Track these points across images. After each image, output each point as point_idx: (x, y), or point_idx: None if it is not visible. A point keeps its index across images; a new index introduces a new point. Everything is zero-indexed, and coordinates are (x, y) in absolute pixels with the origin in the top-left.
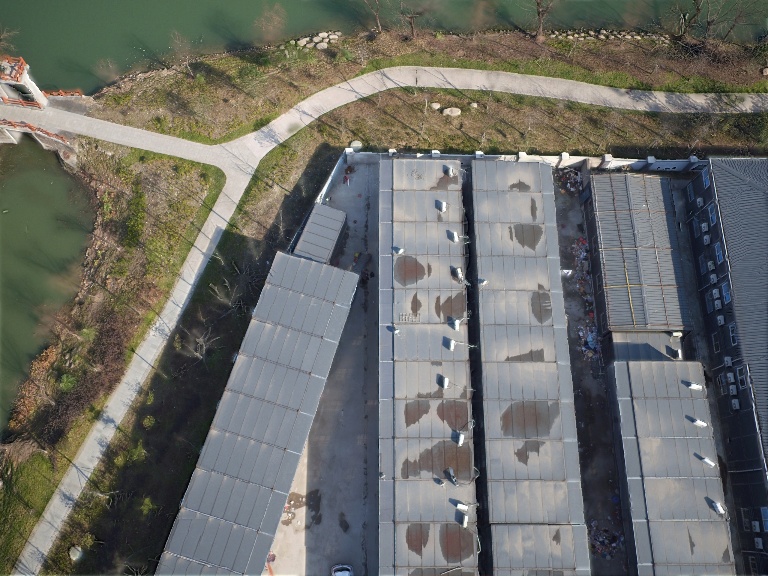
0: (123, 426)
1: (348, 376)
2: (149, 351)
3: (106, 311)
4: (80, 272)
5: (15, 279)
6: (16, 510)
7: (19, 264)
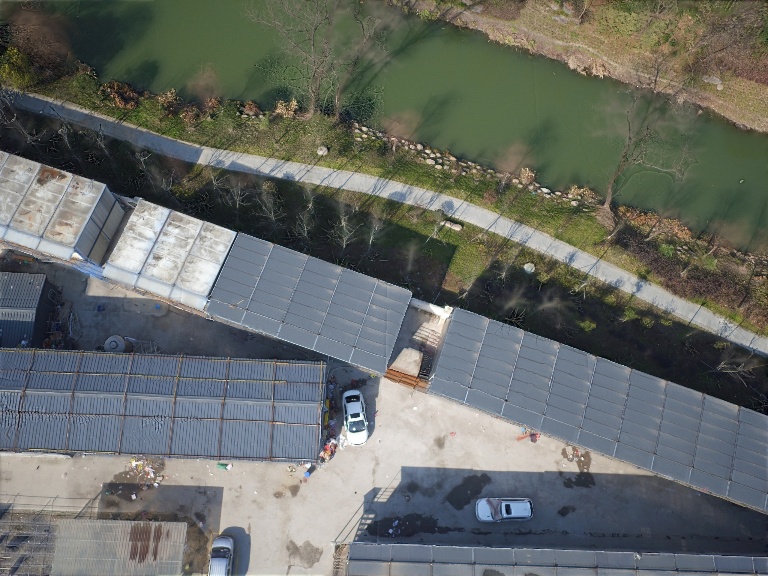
0: (635, 299)
1: (708, 519)
2: (704, 319)
3: (734, 278)
4: (760, 252)
5: (745, 198)
6: (558, 218)
7: (759, 200)
